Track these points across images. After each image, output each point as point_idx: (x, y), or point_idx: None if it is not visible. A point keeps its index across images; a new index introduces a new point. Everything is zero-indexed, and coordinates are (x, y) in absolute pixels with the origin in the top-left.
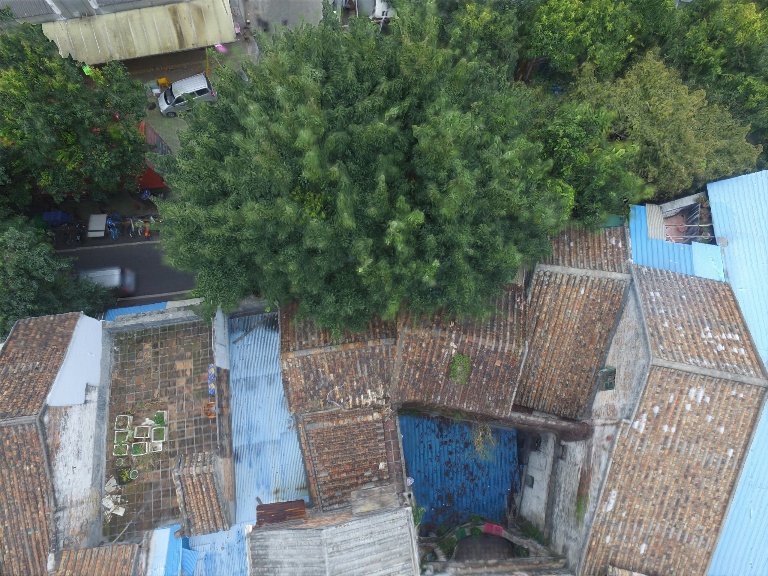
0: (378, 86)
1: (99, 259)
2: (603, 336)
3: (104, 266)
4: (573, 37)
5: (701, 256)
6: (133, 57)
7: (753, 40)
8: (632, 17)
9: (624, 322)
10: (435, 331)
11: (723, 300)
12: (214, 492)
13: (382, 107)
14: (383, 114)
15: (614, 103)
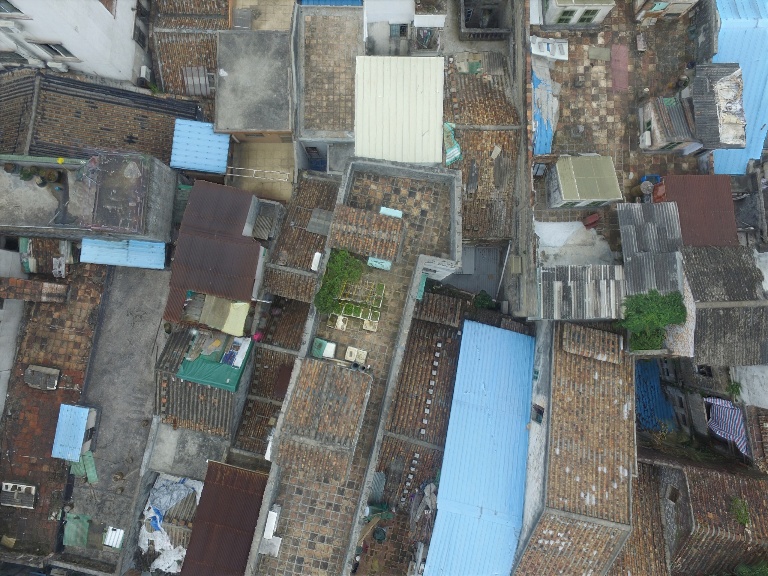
0: None
1: None
2: None
3: None
4: None
5: None
6: None
7: None
8: None
9: None
10: (767, 544)
11: (528, 568)
12: None
13: None
14: None
15: None
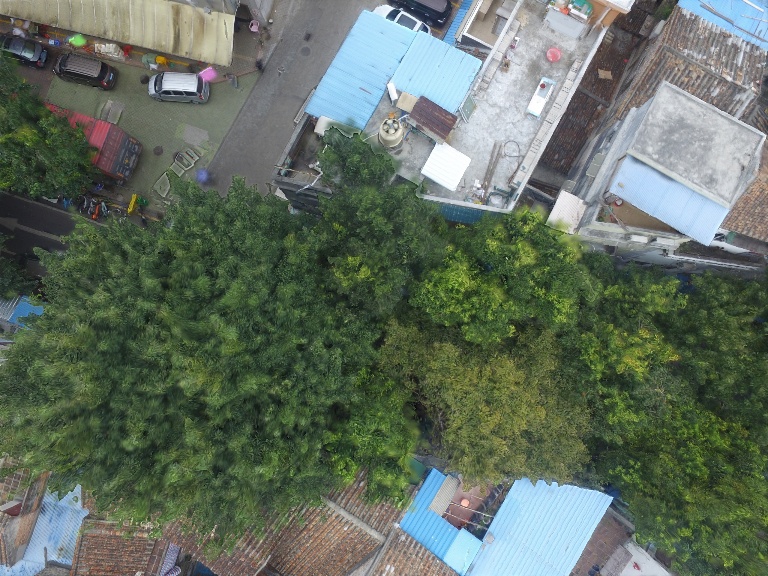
0: (173, 369)
1: (49, 220)
2: (350, 563)
3: (51, 229)
4: (452, 311)
5: (461, 544)
6: (125, 42)
7: (635, 374)
8: (522, 312)
9: (361, 571)
10: None
11: None
12: (3, 543)
13: (177, 380)
14: (176, 385)
15: (448, 397)
